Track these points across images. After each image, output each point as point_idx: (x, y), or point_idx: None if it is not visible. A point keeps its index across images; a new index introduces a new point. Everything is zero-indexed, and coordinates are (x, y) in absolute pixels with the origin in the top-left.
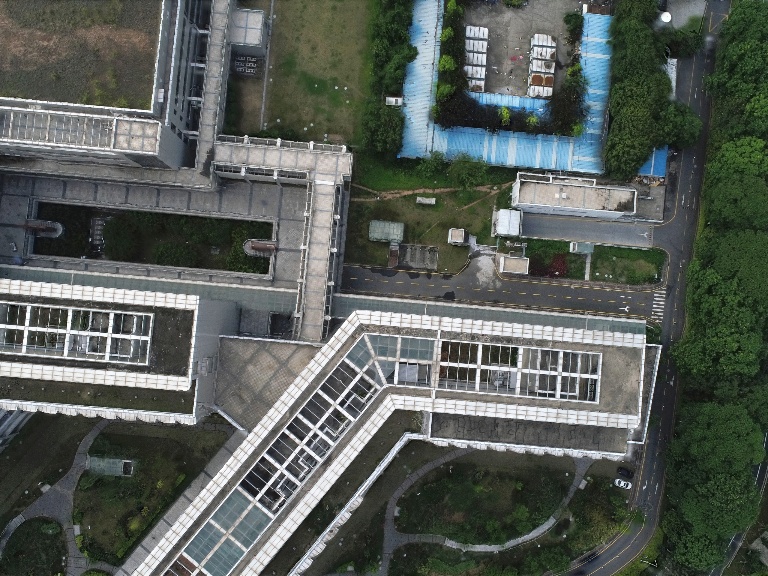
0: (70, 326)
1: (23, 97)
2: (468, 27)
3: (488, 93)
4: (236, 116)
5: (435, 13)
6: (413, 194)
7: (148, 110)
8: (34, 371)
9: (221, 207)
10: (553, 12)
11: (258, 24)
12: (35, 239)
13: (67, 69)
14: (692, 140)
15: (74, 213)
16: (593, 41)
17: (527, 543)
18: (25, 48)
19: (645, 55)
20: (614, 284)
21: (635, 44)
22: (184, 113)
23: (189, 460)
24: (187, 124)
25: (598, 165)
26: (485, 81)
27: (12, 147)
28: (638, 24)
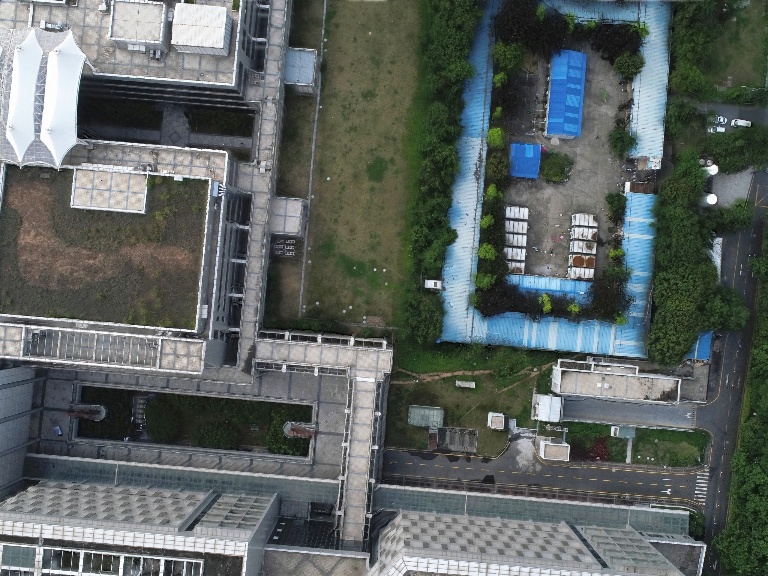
0: (122, 572)
1: (70, 317)
2: (508, 208)
3: (528, 275)
4: (276, 303)
5: (474, 194)
6: (452, 376)
7: (193, 330)
8: None
9: (261, 390)
10: (594, 187)
11: (297, 212)
12: (79, 421)
13: (113, 288)
14: (738, 328)
15: (117, 394)
16: (636, 221)
17: None
18: (71, 267)
19: (691, 248)
20: (656, 467)
21: (680, 234)
22: (226, 312)
23: None
24: (229, 323)
25: (640, 349)
26: (525, 263)
27: None
28: (683, 212)
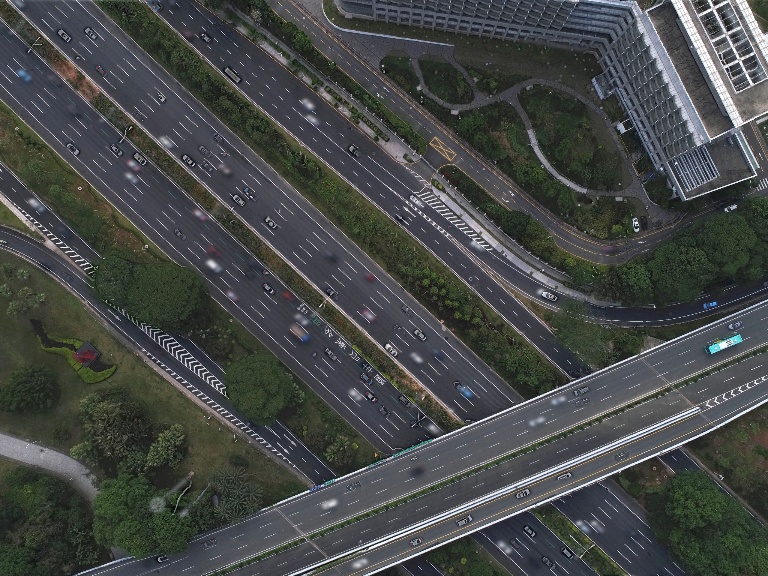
0: None
1: None
2: None
3: None
4: None
5: None
6: None
7: None
8: None
9: None
10: None
11: None
12: None
13: None
14: None
15: None
16: None
17: (560, 183)
18: None
19: None
20: (765, 143)
21: None
22: None
23: None
24: None
25: None
26: None
27: None
28: None
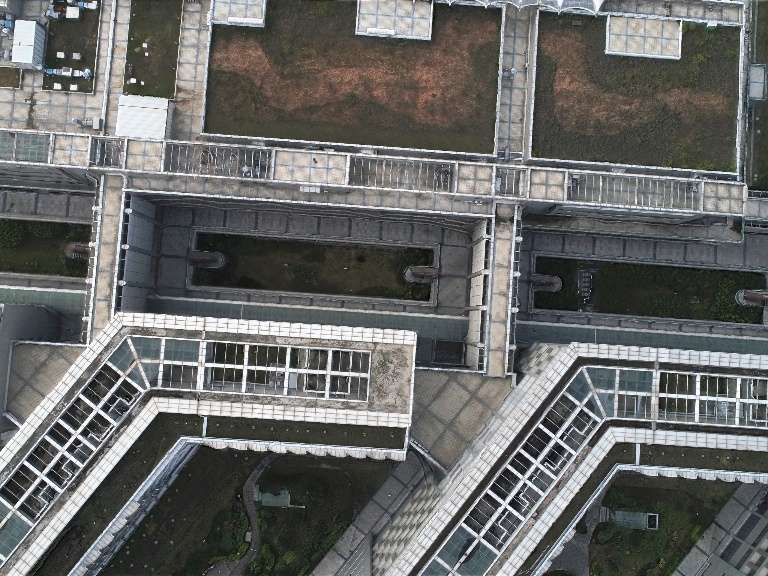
0: (739, 394)
1: (610, 161)
2: None
3: None
4: None
5: None
6: None
7: (734, 172)
8: (709, 440)
9: (716, 258)
10: None
11: (761, 78)
12: None
13: (650, 133)
14: None
15: (567, 266)
16: None
17: None
18: (607, 112)
19: None
20: None
21: None
22: None
23: (700, 511)
24: None
25: None
26: None
27: (583, 209)
28: None
